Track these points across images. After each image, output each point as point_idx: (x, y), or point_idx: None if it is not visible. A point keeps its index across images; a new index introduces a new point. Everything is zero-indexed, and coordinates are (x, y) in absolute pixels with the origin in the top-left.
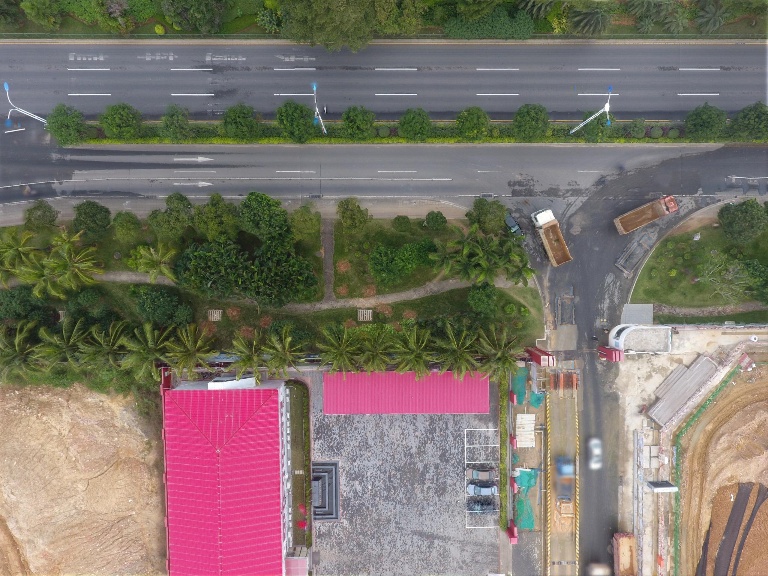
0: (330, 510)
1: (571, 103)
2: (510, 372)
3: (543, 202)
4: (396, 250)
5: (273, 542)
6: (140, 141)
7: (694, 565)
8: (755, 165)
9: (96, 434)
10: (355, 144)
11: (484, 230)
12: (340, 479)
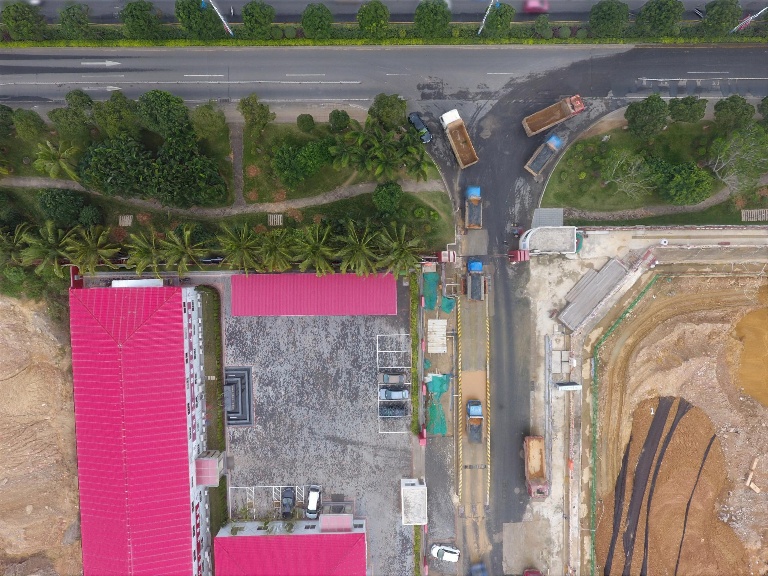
0: (244, 416)
1: (479, 4)
2: (421, 277)
3: (452, 105)
4: (299, 148)
5: (179, 439)
6: (46, 44)
7: (614, 477)
8: (666, 67)
9: (7, 337)
10: (263, 47)
11: (385, 126)
12: (253, 385)
